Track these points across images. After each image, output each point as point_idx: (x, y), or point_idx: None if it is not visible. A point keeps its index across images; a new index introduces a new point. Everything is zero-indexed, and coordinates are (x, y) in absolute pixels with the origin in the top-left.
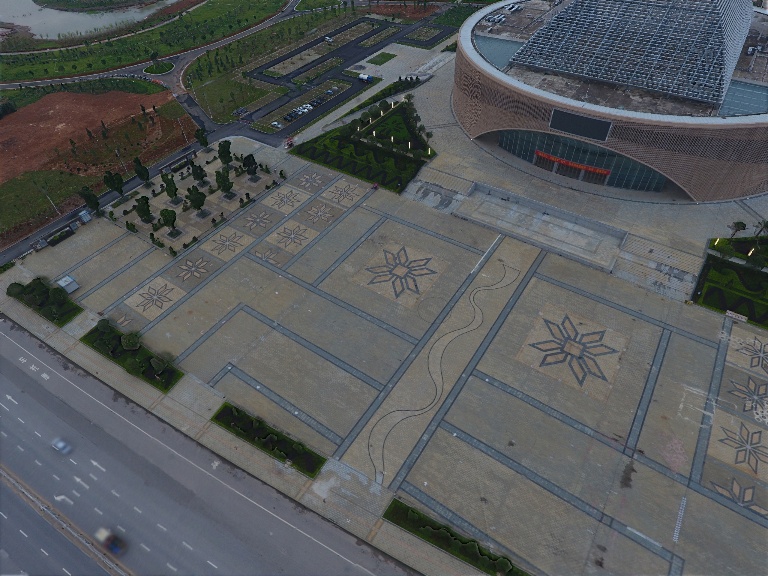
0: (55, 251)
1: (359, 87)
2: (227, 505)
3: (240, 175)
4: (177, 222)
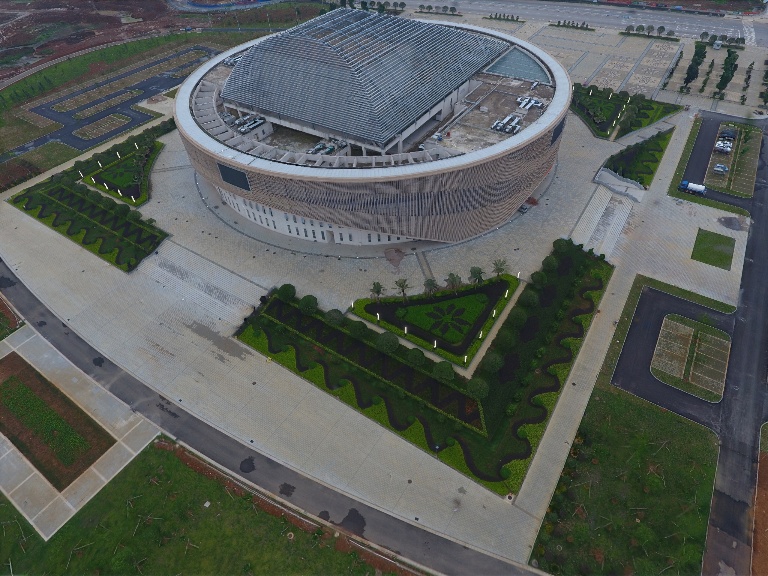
0: (759, 58)
1: (691, 181)
2: (574, 21)
3: (700, 89)
4: (704, 68)
